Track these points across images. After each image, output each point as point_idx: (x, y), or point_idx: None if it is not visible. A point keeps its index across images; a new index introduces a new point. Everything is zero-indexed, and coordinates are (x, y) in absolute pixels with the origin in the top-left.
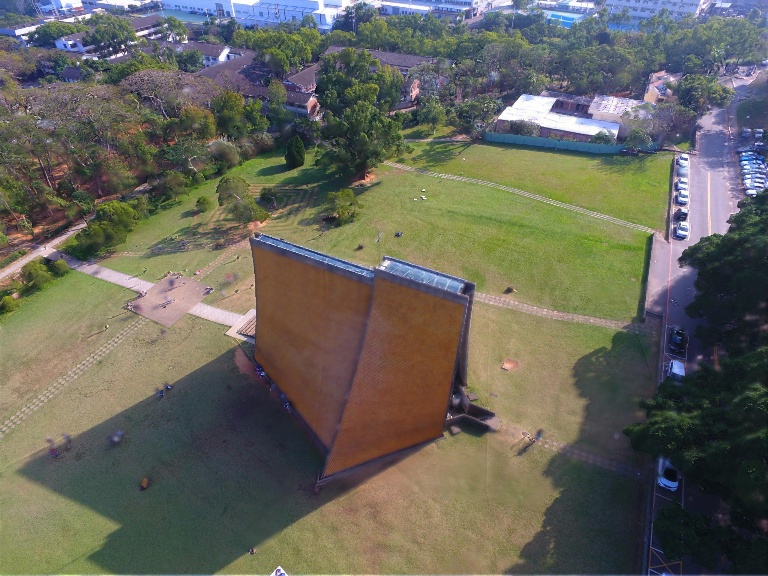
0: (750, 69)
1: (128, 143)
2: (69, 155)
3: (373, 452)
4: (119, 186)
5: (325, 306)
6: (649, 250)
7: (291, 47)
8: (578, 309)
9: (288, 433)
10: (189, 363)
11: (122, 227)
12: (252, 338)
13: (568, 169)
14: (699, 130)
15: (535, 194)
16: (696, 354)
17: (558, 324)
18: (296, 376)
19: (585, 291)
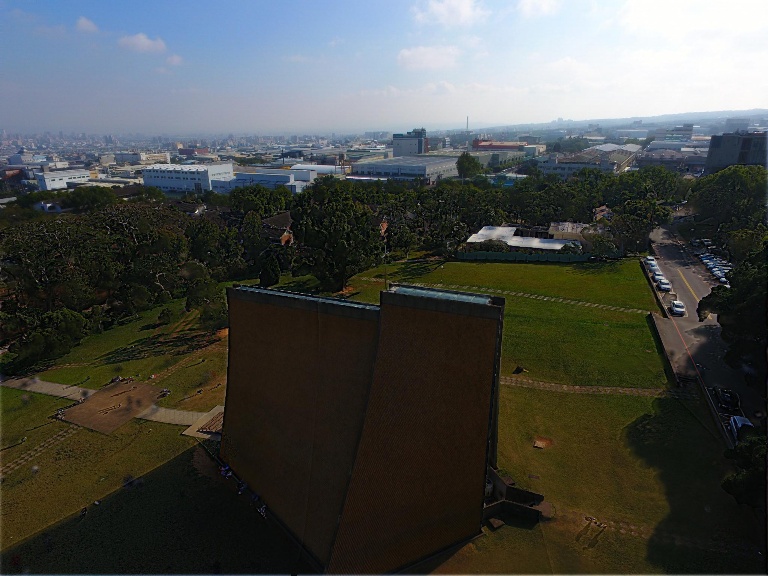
0: (674, 207)
1: (92, 260)
2: (23, 269)
3: (389, 560)
4: (73, 300)
5: (317, 361)
6: (653, 326)
7: (266, 196)
8: (601, 381)
9: (264, 547)
10: (129, 471)
11: (68, 336)
12: (217, 434)
13: (545, 274)
14: (653, 243)
15: (519, 292)
16: (753, 412)
17: (584, 397)
18: (276, 465)
19: (602, 365)
